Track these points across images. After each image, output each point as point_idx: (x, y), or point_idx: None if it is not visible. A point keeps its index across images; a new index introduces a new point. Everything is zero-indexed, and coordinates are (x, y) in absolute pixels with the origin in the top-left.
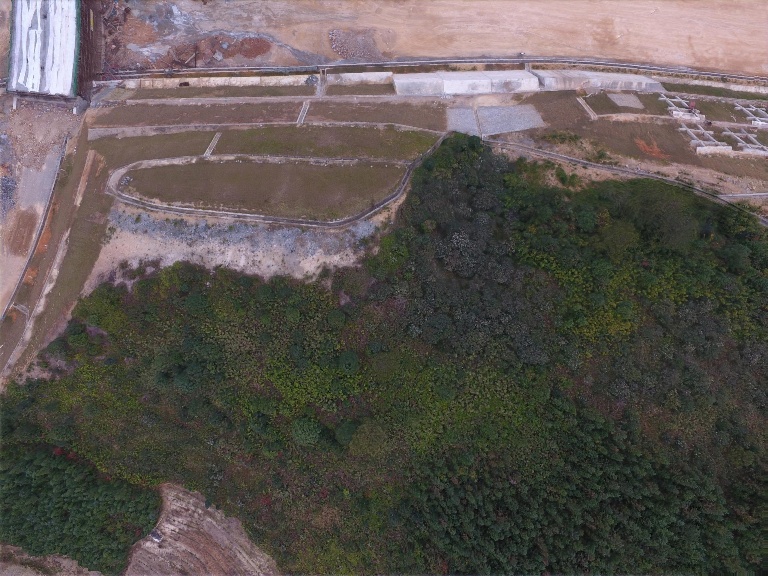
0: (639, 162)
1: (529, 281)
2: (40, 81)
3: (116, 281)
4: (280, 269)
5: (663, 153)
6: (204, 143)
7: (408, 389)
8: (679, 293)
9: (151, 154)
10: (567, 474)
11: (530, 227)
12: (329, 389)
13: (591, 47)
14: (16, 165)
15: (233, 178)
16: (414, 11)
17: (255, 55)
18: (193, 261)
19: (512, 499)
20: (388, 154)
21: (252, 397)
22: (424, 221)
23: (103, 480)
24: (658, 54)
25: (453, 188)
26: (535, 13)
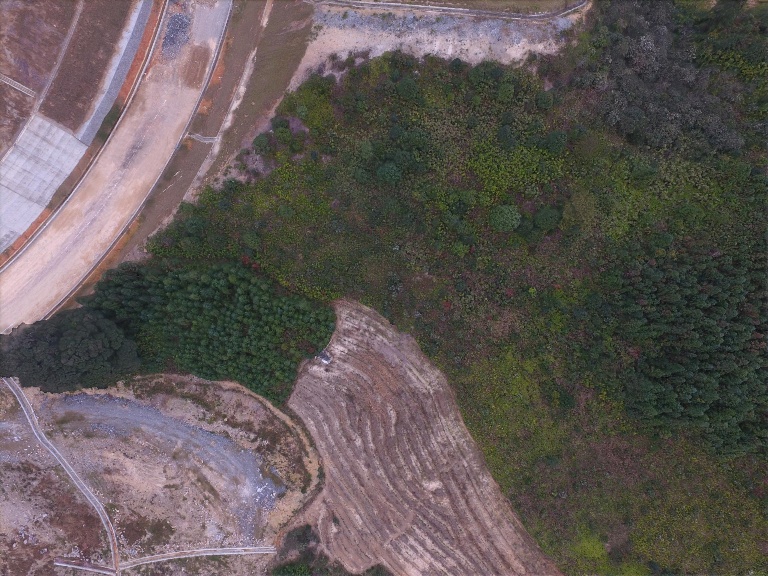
0: None
1: (713, 81)
2: None
3: (325, 73)
4: (488, 56)
5: None
6: None
7: (604, 177)
8: None
9: None
10: None
11: (712, 32)
12: (536, 169)
13: None
14: (190, 3)
15: None
16: None
17: None
18: (402, 51)
19: (716, 269)
20: None
21: (450, 189)
22: (616, 21)
23: (283, 294)
24: None
25: (633, 1)
26: None
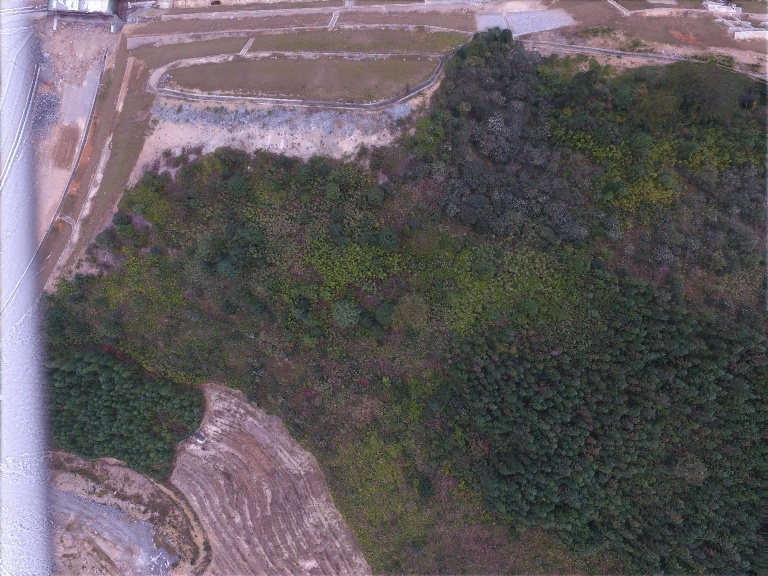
0: (675, 47)
1: (566, 163)
2: None
3: (160, 170)
4: (319, 150)
5: (700, 41)
6: (239, 44)
7: (447, 269)
8: (722, 159)
9: (189, 54)
10: (610, 340)
11: (566, 110)
12: (369, 266)
13: None
14: (58, 82)
15: (270, 71)
16: None
17: None
18: (234, 146)
19: (554, 369)
20: (420, 48)
21: (293, 283)
22: (459, 104)
23: (149, 379)
24: None
25: (487, 76)
26: None
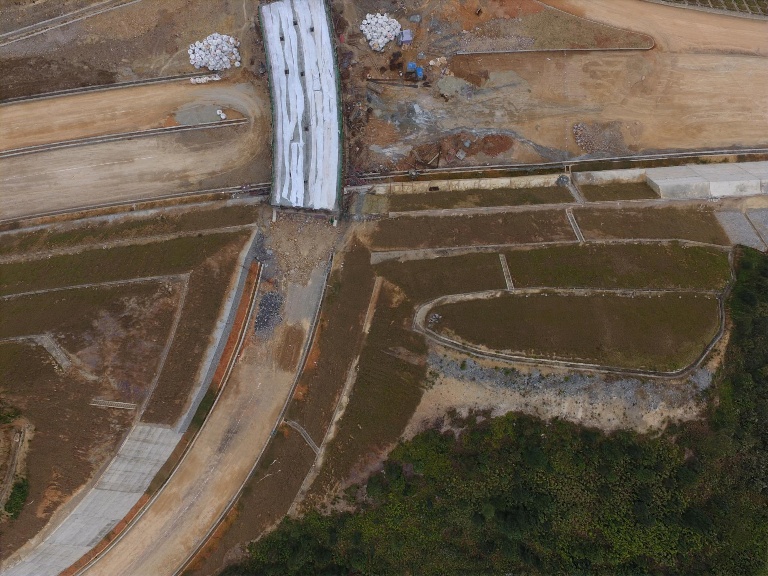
0: None
1: None
2: (304, 195)
3: (443, 428)
4: (622, 423)
5: None
6: (498, 271)
7: (746, 542)
8: None
9: (452, 287)
10: None
11: None
12: (674, 546)
13: None
14: (282, 280)
15: (548, 317)
16: (661, 101)
17: (498, 153)
18: (527, 412)
19: None
20: (693, 282)
21: (574, 542)
22: (760, 366)
23: None
24: None
25: None
26: None
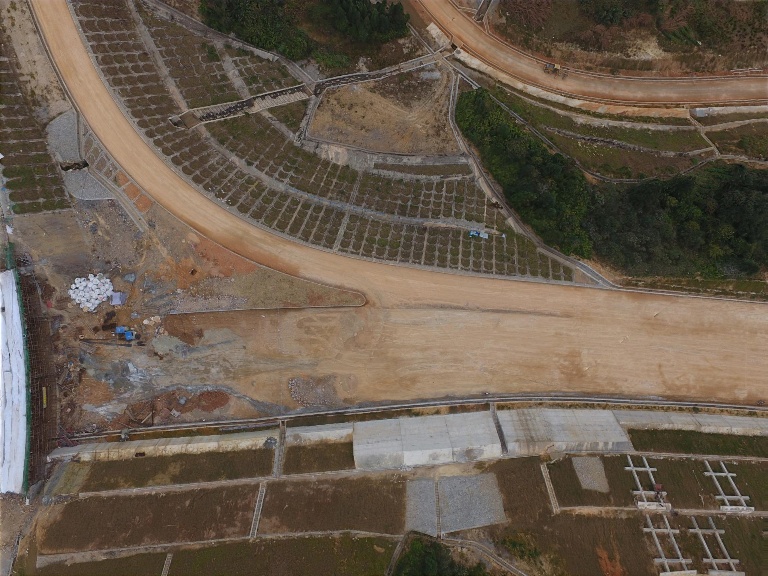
0: None
1: None
2: None
3: None
4: None
5: (625, 575)
6: None
7: None
8: None
9: None
10: None
11: None
12: None
13: (558, 381)
14: None
15: None
16: (375, 354)
17: (213, 409)
18: None
19: None
20: None
21: None
22: None
23: None
24: (627, 384)
25: None
26: (500, 349)
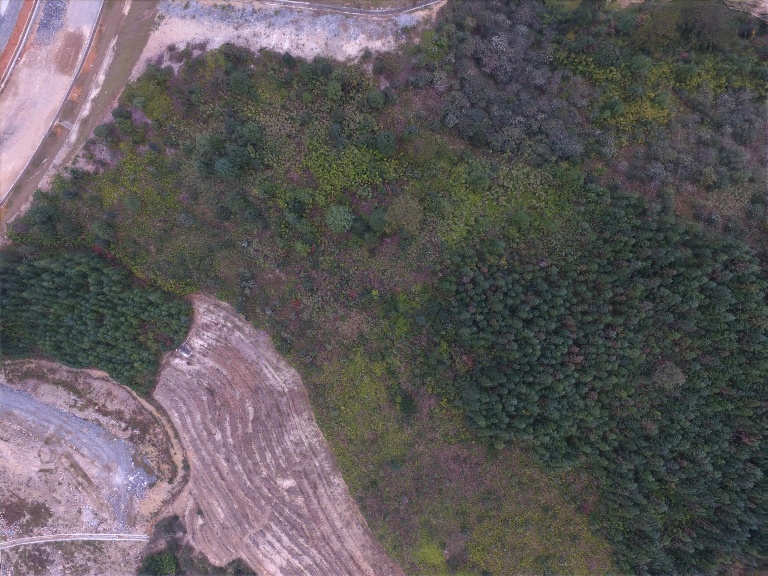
0: None
1: (566, 85)
2: None
3: (163, 64)
4: (323, 52)
5: None
6: None
7: (442, 180)
8: (718, 83)
9: None
10: (598, 250)
11: (569, 34)
12: (366, 169)
13: None
14: None
15: None
16: None
17: None
18: (239, 44)
19: (542, 280)
20: None
21: (289, 187)
22: (465, 19)
23: (138, 285)
24: None
25: None
26: None
